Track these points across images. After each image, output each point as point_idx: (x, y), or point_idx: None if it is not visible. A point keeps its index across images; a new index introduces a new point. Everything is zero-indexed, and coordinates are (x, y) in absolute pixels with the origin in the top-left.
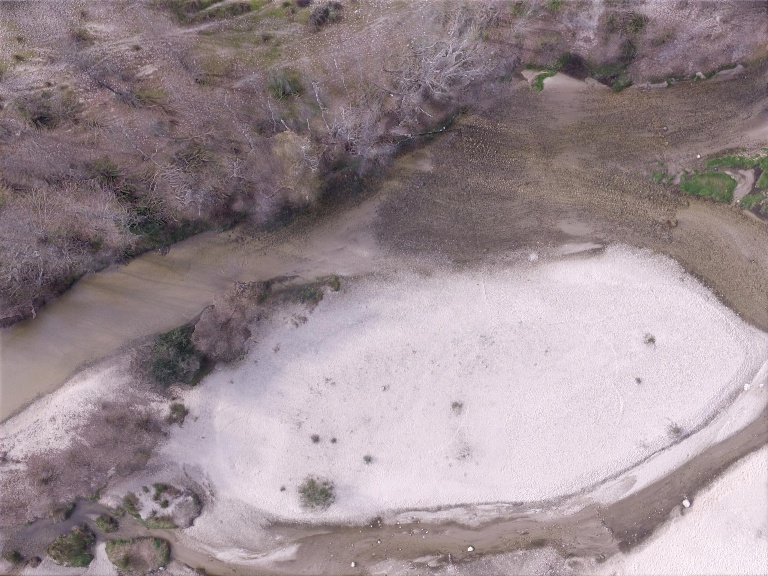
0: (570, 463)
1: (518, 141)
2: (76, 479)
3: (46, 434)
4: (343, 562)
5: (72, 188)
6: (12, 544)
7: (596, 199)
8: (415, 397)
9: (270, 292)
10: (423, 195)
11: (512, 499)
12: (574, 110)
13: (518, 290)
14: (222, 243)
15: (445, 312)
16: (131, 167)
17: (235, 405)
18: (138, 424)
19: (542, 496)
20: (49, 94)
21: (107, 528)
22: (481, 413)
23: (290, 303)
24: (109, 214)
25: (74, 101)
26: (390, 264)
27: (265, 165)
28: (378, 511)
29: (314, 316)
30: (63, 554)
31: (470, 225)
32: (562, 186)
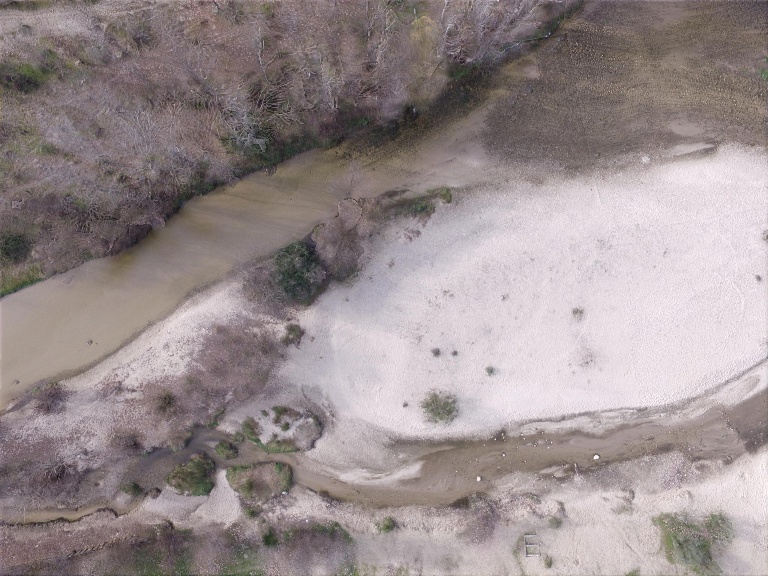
0: (694, 364)
1: (625, 43)
2: (194, 406)
3: (161, 361)
4: (468, 477)
5: (176, 109)
6: (130, 476)
7: (705, 99)
8: (535, 305)
9: (381, 207)
10: (531, 102)
11: (636, 404)
12: (680, 10)
13: (632, 193)
14: (329, 160)
15: (560, 218)
16: (236, 85)
17: (352, 323)
18: (254, 346)
19: (666, 400)
20: (149, 14)
21: (227, 454)
22: (602, 318)
23: (402, 218)
24: (246, 109)
25: (175, 20)
26: (501, 173)
27: (406, 50)
28: (501, 423)
29: (427, 229)
30: (185, 481)
31: (580, 130)
32: (671, 87)
